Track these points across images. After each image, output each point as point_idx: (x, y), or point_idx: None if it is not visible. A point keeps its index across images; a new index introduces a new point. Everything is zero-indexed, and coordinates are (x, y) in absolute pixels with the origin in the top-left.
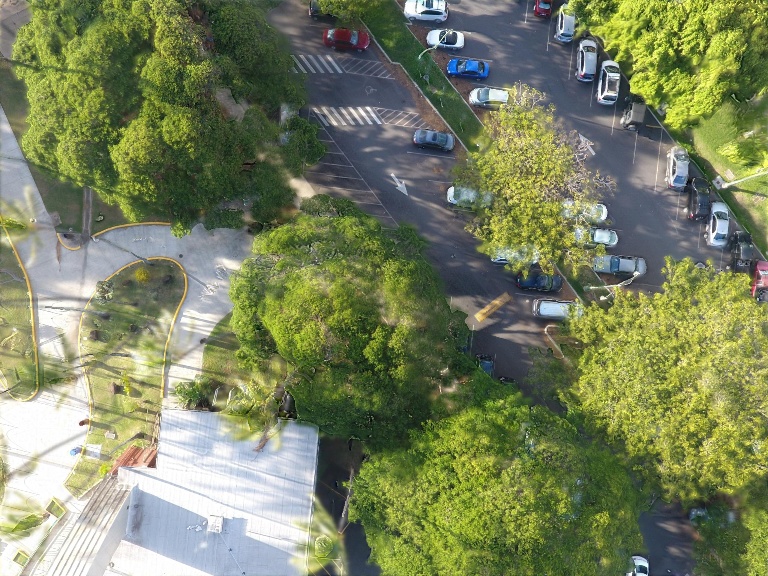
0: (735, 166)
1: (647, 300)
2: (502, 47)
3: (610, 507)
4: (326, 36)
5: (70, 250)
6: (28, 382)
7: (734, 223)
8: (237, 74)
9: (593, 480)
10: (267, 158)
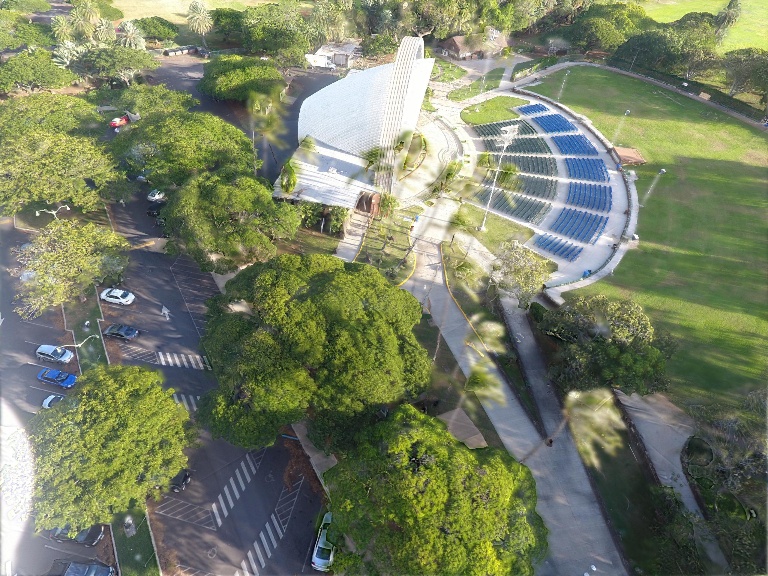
0: None
1: None
2: (12, 397)
3: None
4: None
5: None
6: (446, 247)
7: None
8: None
9: None
10: None
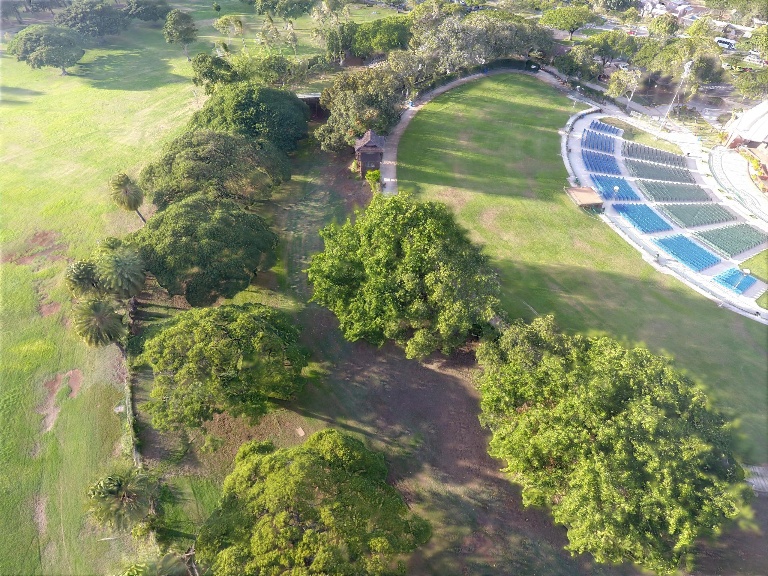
0: None
1: None
2: None
3: None
4: None
5: None
6: None
7: None
8: None
9: None
10: None
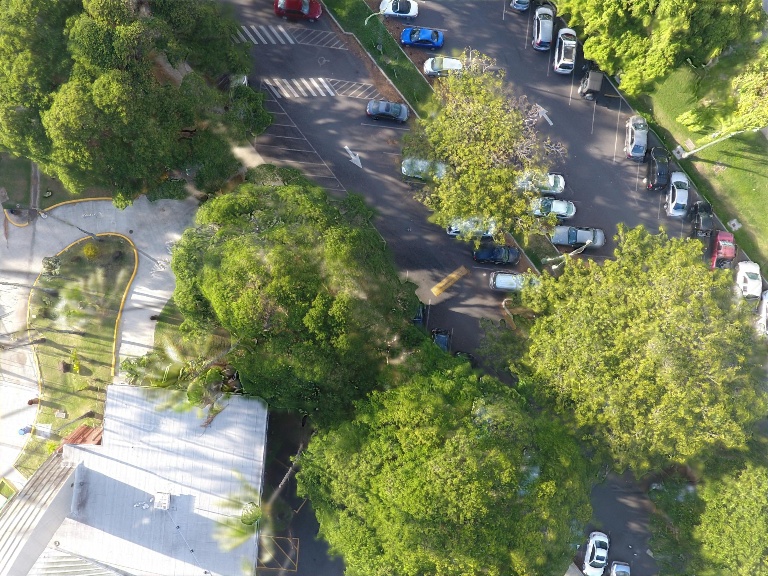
0: (695, 135)
1: (597, 267)
2: (457, 16)
3: (558, 477)
4: (276, 6)
5: (18, 227)
6: None
7: (695, 193)
8: (171, 37)
9: (541, 450)
10: (209, 126)
